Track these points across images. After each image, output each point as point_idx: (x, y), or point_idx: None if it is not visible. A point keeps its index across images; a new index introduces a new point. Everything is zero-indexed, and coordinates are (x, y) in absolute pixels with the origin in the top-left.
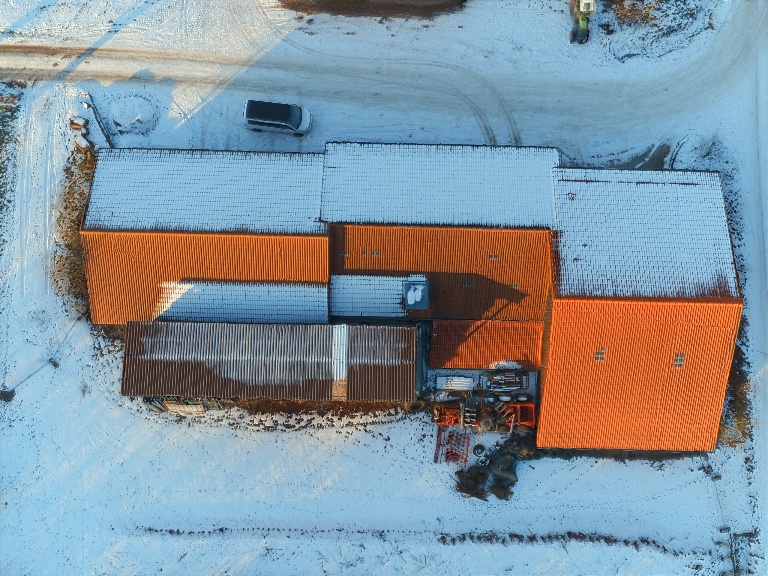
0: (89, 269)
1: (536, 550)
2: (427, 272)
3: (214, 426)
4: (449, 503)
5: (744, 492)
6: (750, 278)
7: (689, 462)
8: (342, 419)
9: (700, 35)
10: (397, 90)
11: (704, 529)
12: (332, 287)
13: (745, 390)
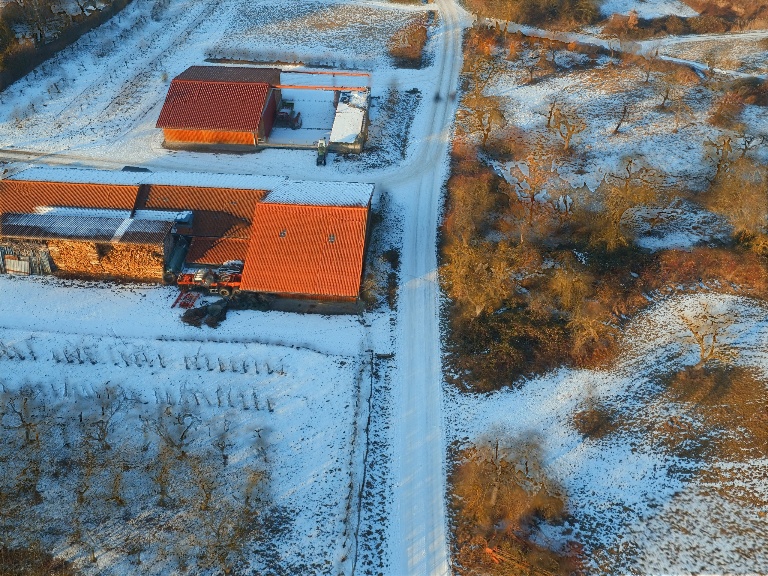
0: None
1: (224, 346)
2: (193, 210)
3: (31, 282)
4: (174, 328)
5: (387, 334)
6: (406, 246)
7: (349, 317)
8: (118, 285)
9: (392, 168)
10: None
11: (354, 350)
12: (135, 216)
13: (395, 289)
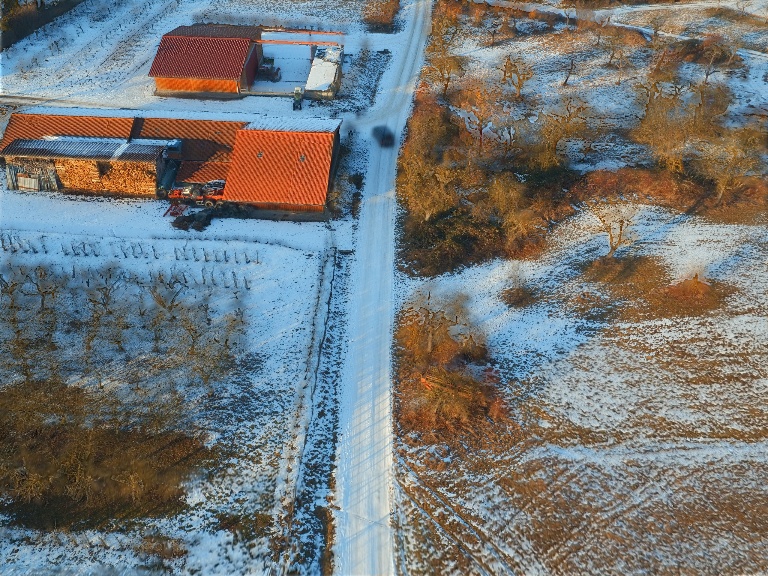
0: (8, 129)
1: (209, 243)
2: (182, 139)
3: (40, 197)
4: (165, 232)
5: (349, 236)
6: (369, 172)
7: (317, 223)
8: (116, 200)
9: None
10: None
11: (320, 247)
12: None
13: (358, 204)
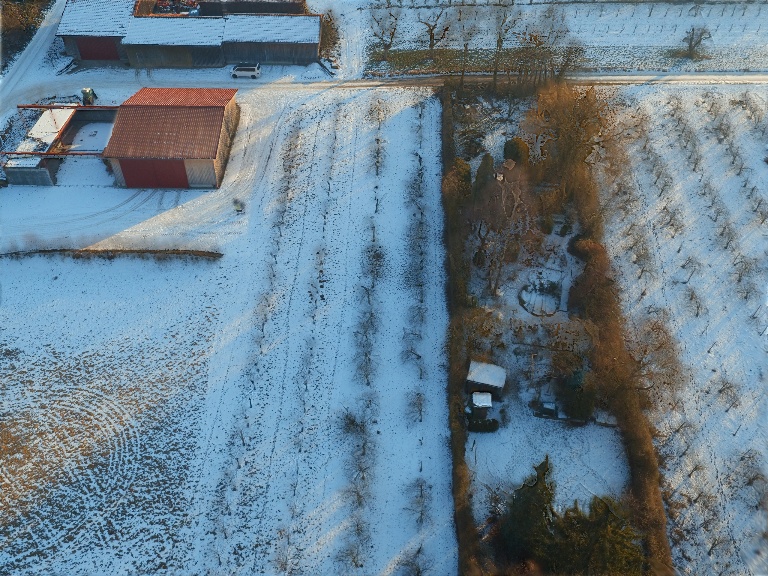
0: None
1: None
2: None
3: None
4: None
5: None
6: None
7: None
8: None
9: None
10: (188, 85)
11: None
12: None
13: None
